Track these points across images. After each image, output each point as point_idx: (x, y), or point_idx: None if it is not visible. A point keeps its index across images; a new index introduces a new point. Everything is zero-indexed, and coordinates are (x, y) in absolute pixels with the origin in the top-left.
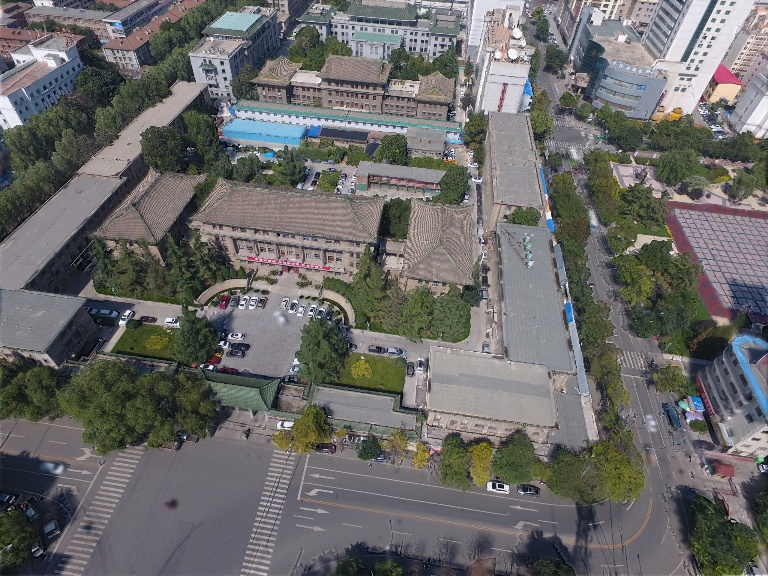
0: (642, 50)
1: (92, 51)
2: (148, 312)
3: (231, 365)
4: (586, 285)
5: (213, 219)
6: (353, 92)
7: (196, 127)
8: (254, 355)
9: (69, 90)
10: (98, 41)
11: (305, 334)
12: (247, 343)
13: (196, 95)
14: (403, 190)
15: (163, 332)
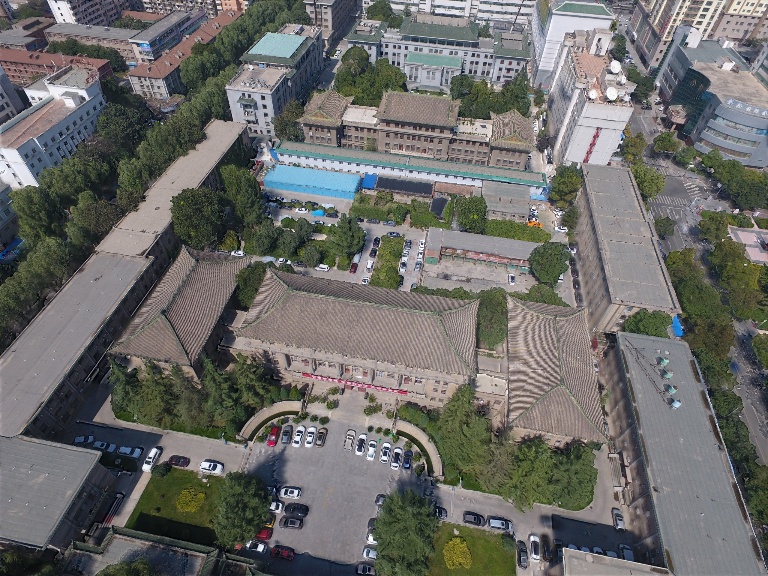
0: (754, 81)
1: (117, 74)
2: (179, 449)
3: (286, 541)
4: (741, 425)
5: (263, 335)
6: (415, 135)
7: (236, 186)
8: (315, 524)
9: (89, 133)
10: (123, 63)
11: (388, 519)
12: (305, 504)
13: (234, 139)
14: (481, 264)
15: (197, 482)
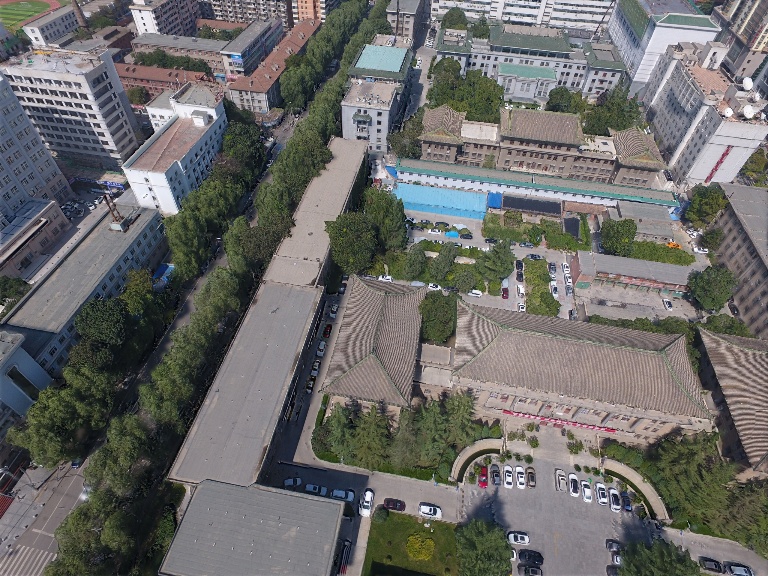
0: None
1: None
2: (389, 491)
3: None
4: None
5: (481, 375)
6: (540, 152)
7: (384, 209)
8: (553, 573)
9: (215, 152)
10: (211, 74)
11: (658, 573)
12: (536, 550)
13: (361, 158)
14: (631, 288)
15: (420, 528)
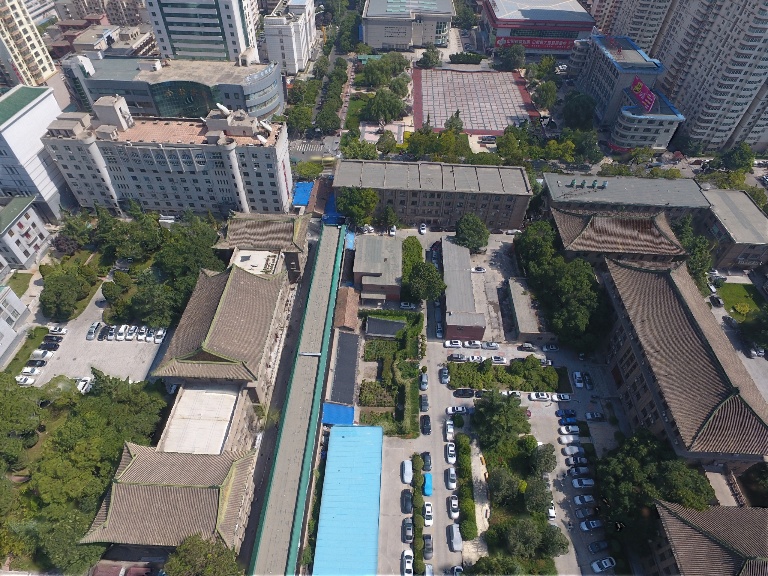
0: (191, 62)
1: None
2: None
3: None
4: None
5: None
6: None
7: None
8: None
9: None
10: None
11: None
12: None
13: None
14: None
15: None
